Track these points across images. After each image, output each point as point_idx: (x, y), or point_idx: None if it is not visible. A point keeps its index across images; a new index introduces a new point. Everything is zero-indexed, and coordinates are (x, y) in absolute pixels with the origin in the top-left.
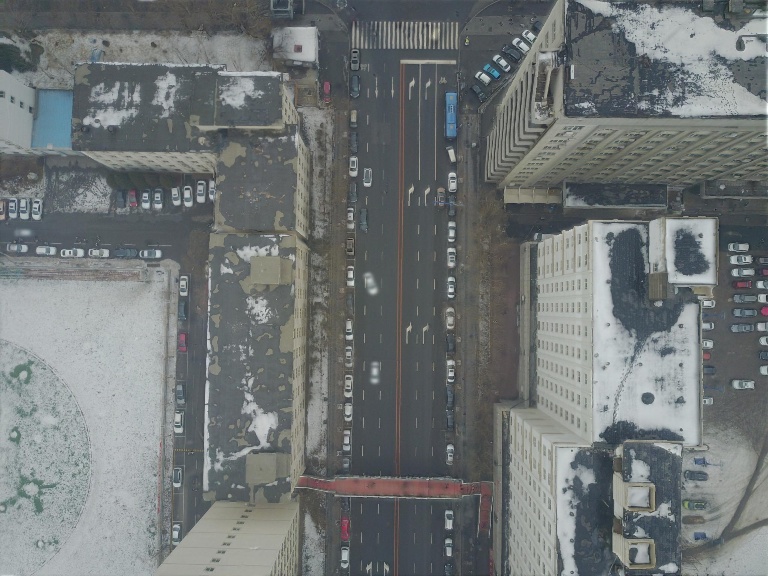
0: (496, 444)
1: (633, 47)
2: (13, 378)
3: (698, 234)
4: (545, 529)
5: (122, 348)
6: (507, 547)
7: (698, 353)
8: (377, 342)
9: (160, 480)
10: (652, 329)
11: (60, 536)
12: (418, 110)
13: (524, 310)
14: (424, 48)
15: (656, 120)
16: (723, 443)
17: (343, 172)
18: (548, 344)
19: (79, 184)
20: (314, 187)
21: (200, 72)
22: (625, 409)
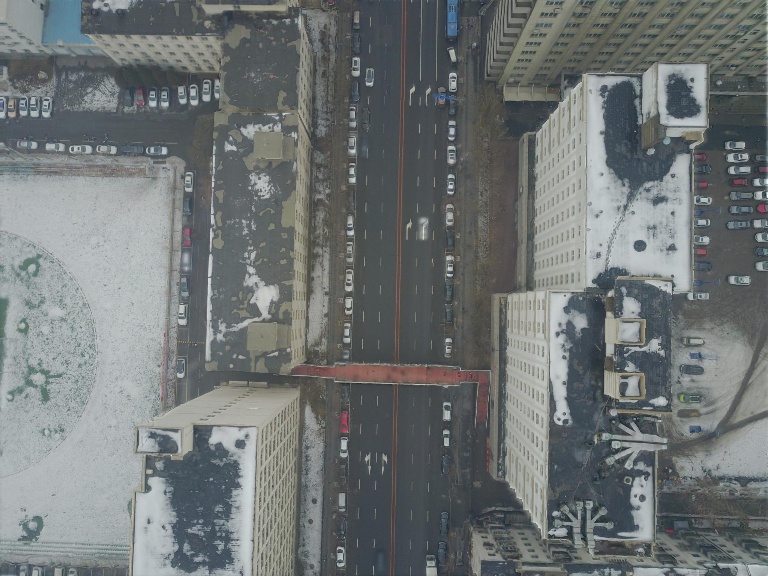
0: (493, 330)
1: None
2: (22, 271)
3: (689, 79)
4: (539, 379)
5: (128, 242)
6: (503, 430)
7: (689, 201)
8: (378, 238)
9: (164, 370)
10: (644, 179)
11: (66, 425)
12: (420, 12)
13: (522, 200)
14: None
15: None
16: (718, 338)
17: (346, 72)
18: (545, 224)
19: (88, 83)
20: (317, 87)
21: None
22: (617, 256)
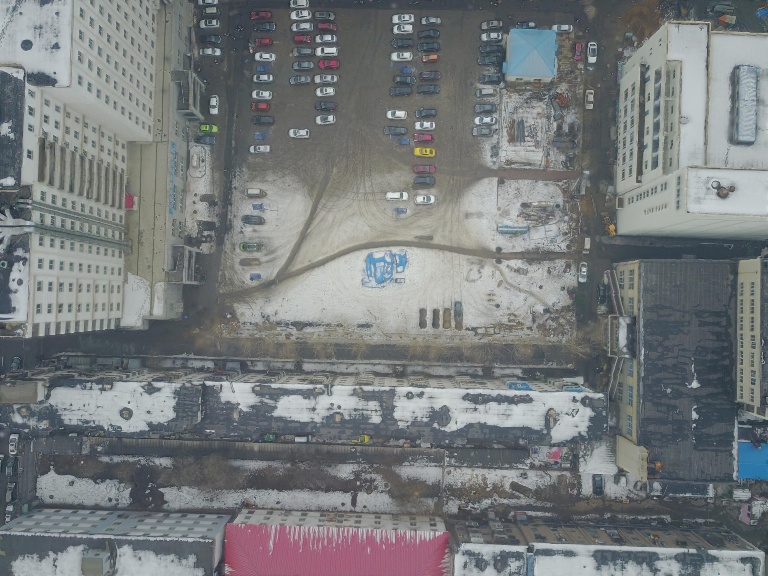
0: None
1: None
2: None
3: None
4: None
5: None
6: None
7: (71, 2)
8: None
9: None
10: None
11: None
12: None
13: None
14: None
15: None
16: (280, 190)
17: None
18: None
19: None
20: None
21: None
22: (5, 55)
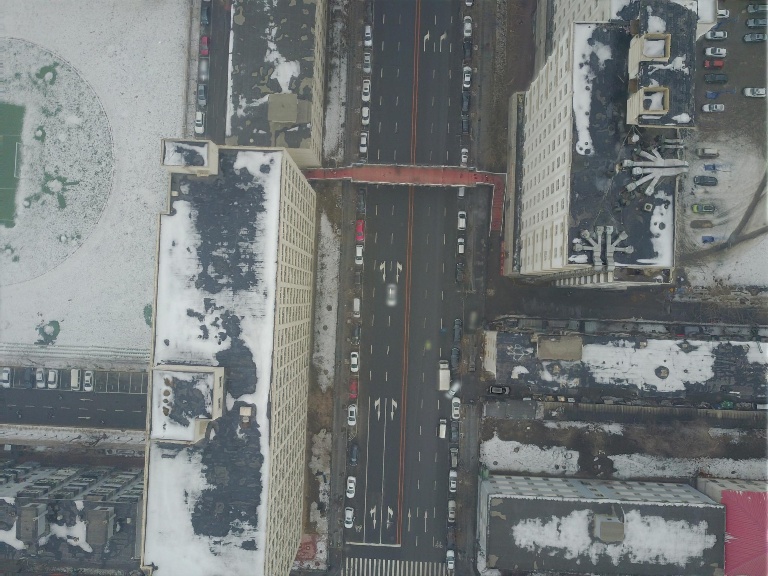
0: (511, 129)
1: None
2: (39, 79)
3: None
4: (560, 122)
5: (145, 51)
6: (519, 225)
7: None
8: (395, 50)
9: None
10: None
11: (82, 231)
12: None
13: (541, 1)
14: None
15: None
16: (733, 150)
17: None
18: (565, 10)
19: None
20: None
21: None
22: None
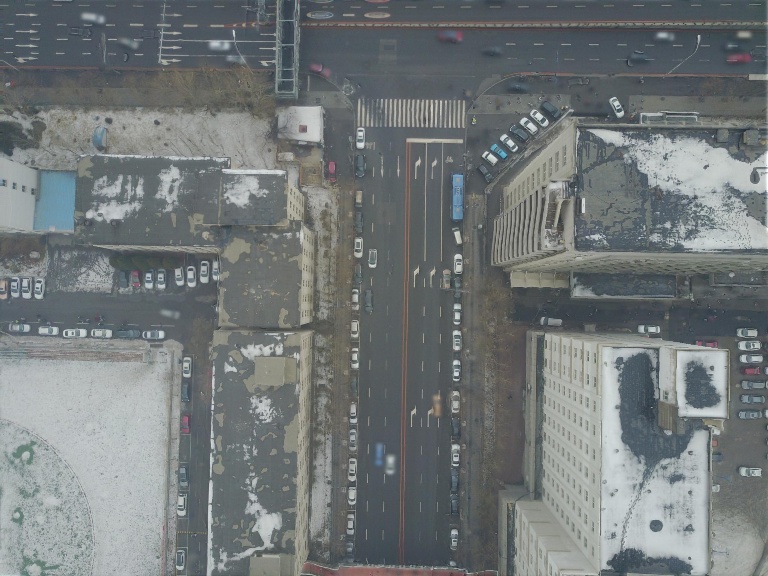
0: (501, 536)
1: (645, 178)
2: (16, 459)
3: (709, 367)
4: None
5: (125, 429)
6: None
7: (707, 481)
8: (381, 425)
9: (163, 563)
10: (661, 455)
11: None
12: (424, 190)
13: (530, 400)
14: (430, 126)
15: (668, 254)
16: (729, 530)
17: (348, 252)
18: (554, 442)
19: (82, 263)
20: (319, 268)
21: (204, 170)
22: (633, 537)
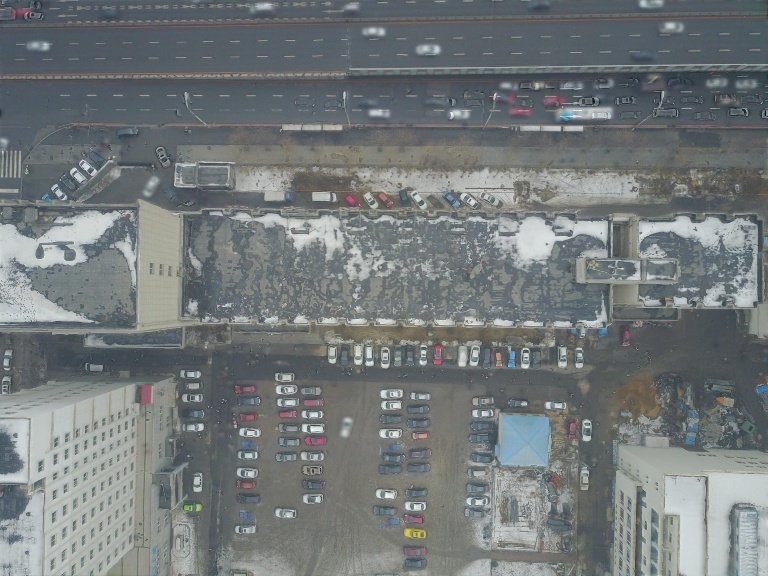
0: None
1: None
2: None
3: (13, 434)
4: None
5: None
6: None
7: (42, 541)
8: None
9: None
10: (2, 517)
11: None
12: None
13: None
14: None
15: None
16: (267, 570)
17: None
18: None
19: None
20: None
21: None
22: None
